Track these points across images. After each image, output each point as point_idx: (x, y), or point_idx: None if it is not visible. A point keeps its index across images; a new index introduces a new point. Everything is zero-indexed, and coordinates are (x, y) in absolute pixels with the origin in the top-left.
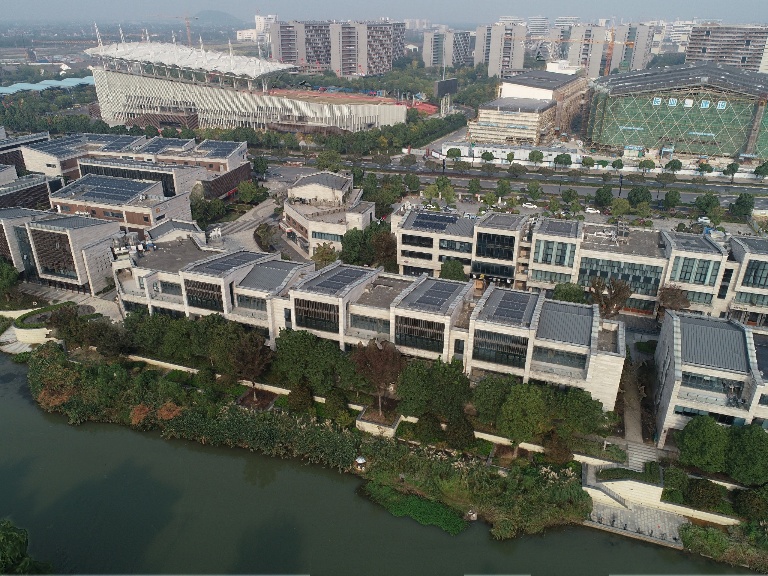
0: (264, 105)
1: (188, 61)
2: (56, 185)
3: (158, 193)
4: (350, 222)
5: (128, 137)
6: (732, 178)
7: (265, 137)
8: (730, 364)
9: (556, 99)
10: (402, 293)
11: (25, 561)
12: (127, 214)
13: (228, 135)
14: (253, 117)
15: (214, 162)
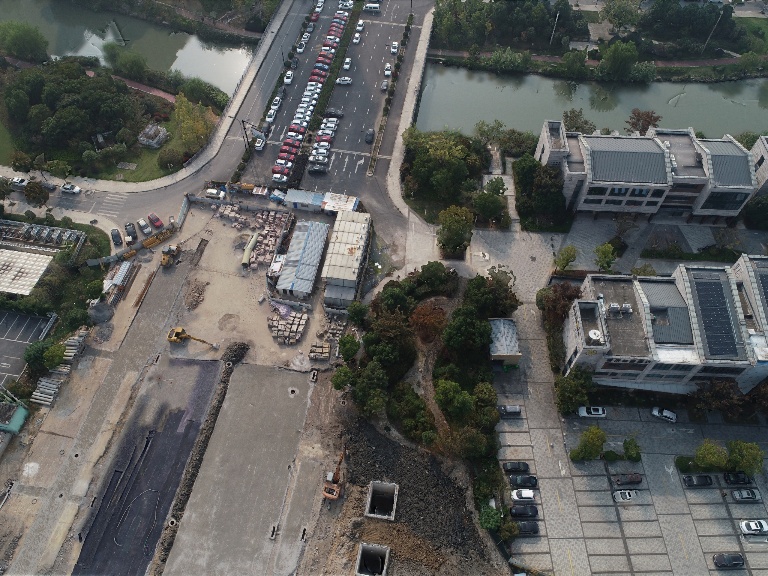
0: None
1: None
2: None
3: None
4: None
5: None
6: None
7: None
8: (707, 143)
9: None
10: None
11: None
12: None
13: None
14: None
15: None
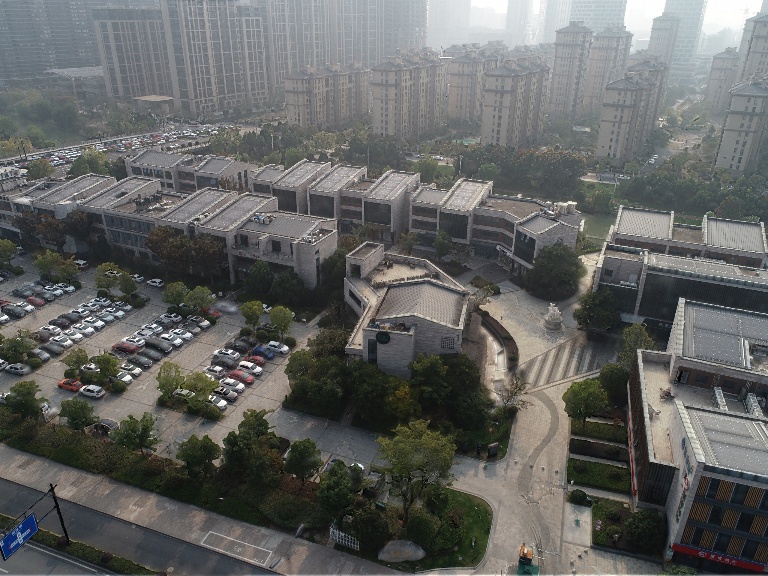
0: None
1: None
2: None
3: None
4: None
5: None
6: None
7: None
8: None
9: None
10: (358, 171)
11: None
12: None
13: None
14: None
15: None
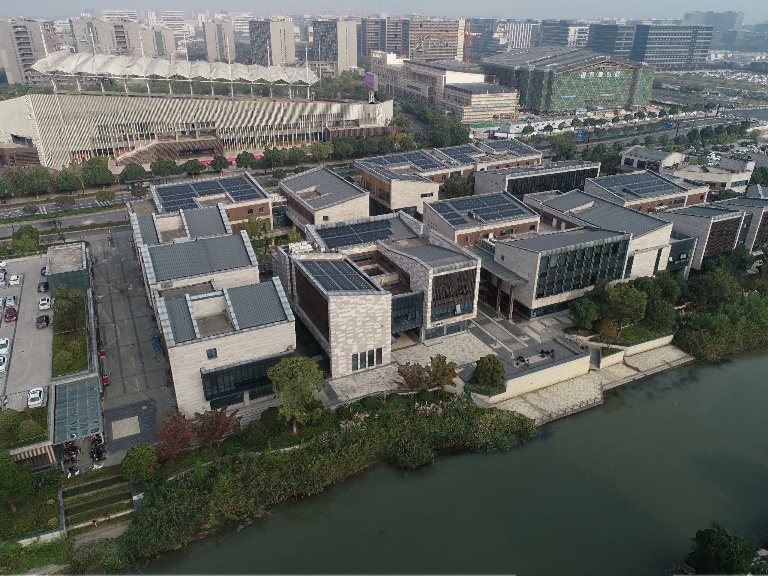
0: (310, 113)
1: (203, 71)
2: None
3: None
4: (748, 169)
5: (409, 154)
6: (670, 118)
7: (387, 142)
8: None
9: (487, 81)
10: None
11: None
12: (689, 198)
13: (349, 147)
14: (295, 128)
15: (531, 159)
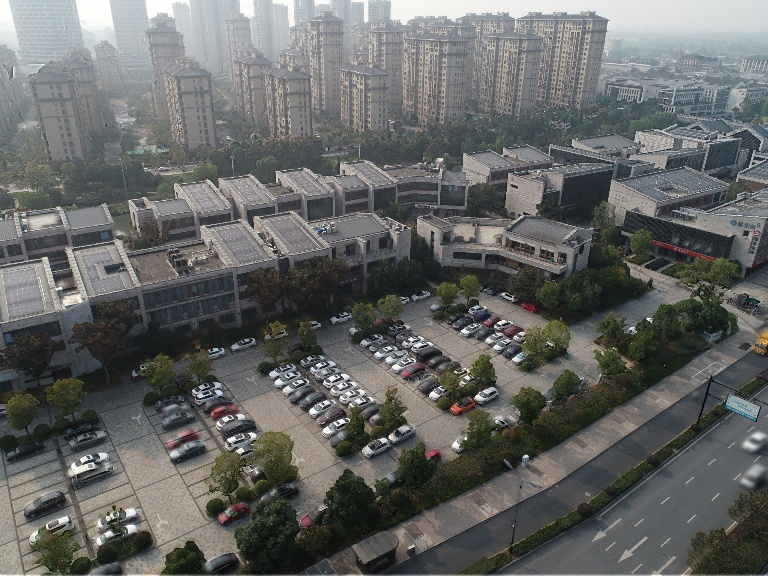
0: None
1: None
2: (627, 170)
3: (558, 181)
4: None
5: None
6: None
7: None
8: None
9: None
10: None
11: (259, 163)
12: None
13: None
14: None
15: None
